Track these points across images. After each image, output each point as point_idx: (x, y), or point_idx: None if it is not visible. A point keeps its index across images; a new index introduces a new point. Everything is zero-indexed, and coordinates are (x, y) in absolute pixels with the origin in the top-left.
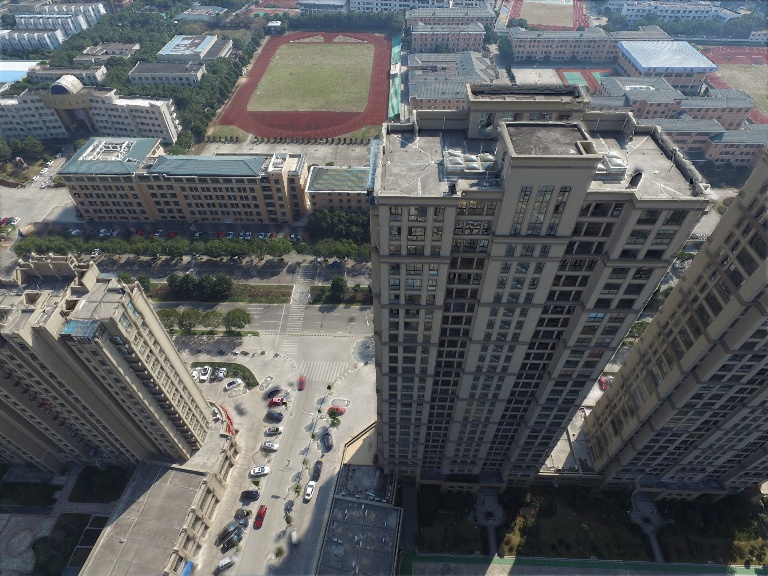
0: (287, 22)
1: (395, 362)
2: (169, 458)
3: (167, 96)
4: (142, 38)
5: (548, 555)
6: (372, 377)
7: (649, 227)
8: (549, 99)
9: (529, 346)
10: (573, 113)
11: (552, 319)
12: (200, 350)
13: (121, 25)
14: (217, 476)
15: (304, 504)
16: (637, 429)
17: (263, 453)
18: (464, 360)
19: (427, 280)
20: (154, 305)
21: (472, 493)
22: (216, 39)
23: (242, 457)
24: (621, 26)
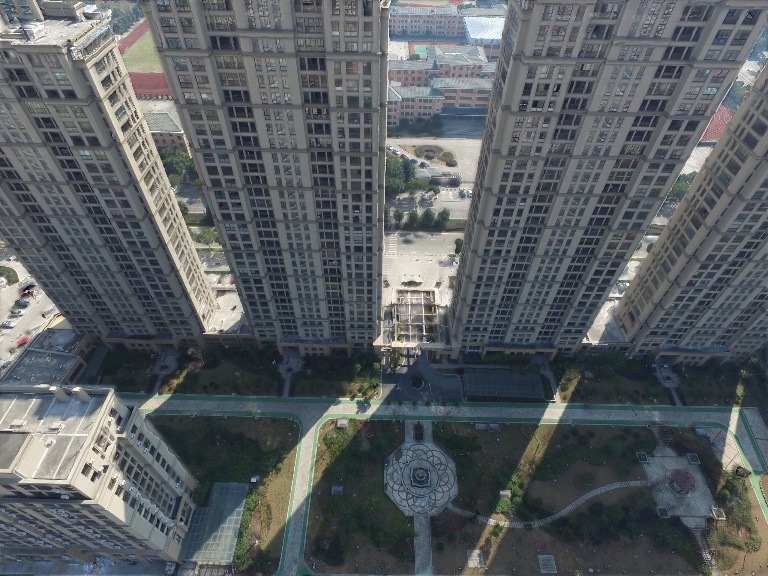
0: None
1: None
2: None
3: None
4: None
5: (198, 393)
6: None
7: (45, 70)
8: None
9: (76, 189)
10: None
11: (68, 161)
12: None
13: None
14: None
15: None
16: (236, 280)
17: None
18: (38, 203)
19: None
20: None
21: (154, 352)
22: (95, 8)
23: None
24: (485, 6)
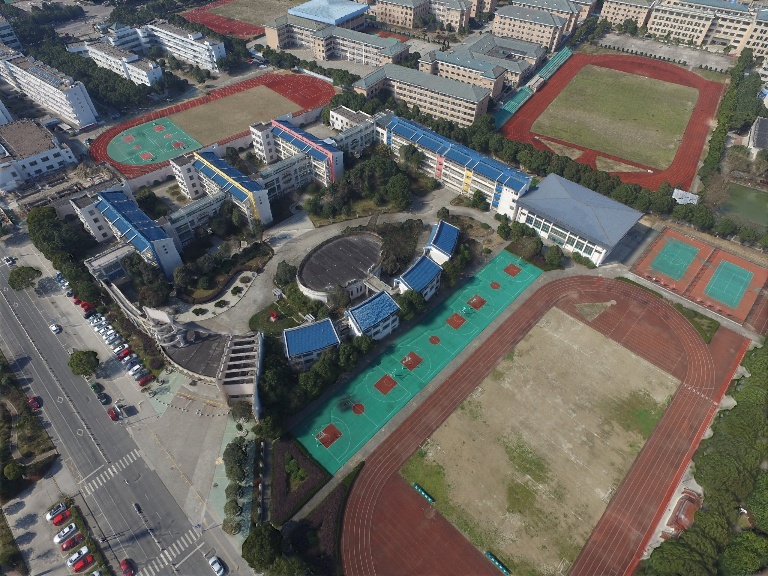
0: None
1: None
2: None
3: None
4: None
5: None
6: None
7: None
8: None
9: None
10: None
11: None
12: None
13: None
14: None
15: None
16: None
17: None
18: None
19: None
20: None
21: None
22: None
23: None
24: None
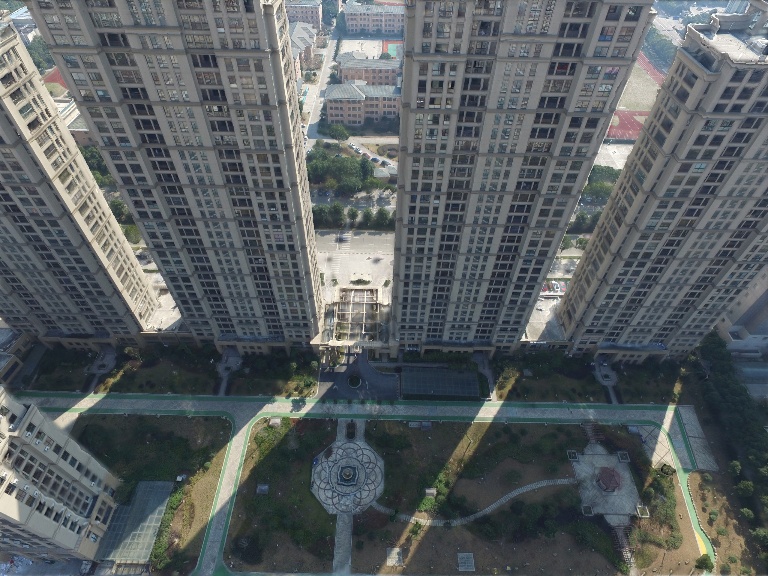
0: None
1: None
2: None
3: None
4: None
5: (133, 392)
6: None
7: None
8: None
9: None
10: None
11: None
12: None
13: None
14: None
15: None
16: None
17: None
18: None
19: None
20: None
21: (93, 350)
22: None
23: None
24: None
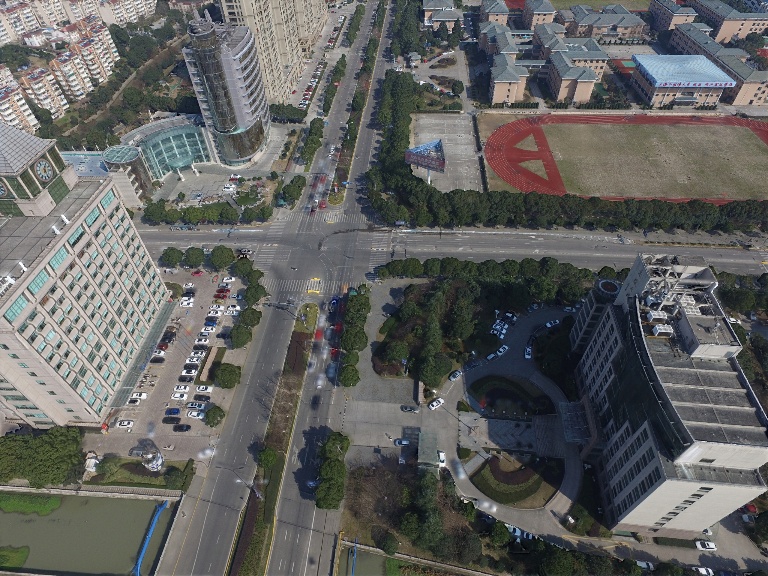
0: None
1: None
2: None
3: None
4: None
5: None
6: (344, 15)
7: None
8: None
9: None
10: None
11: None
12: None
13: None
14: None
15: None
16: None
17: None
18: None
19: None
20: None
21: None
22: None
23: None
24: None
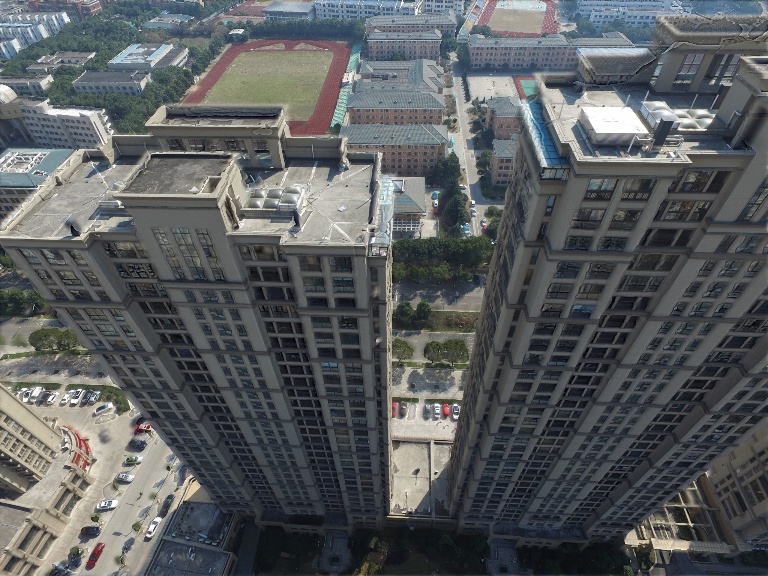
0: (249, 30)
1: (150, 407)
2: (1, 491)
3: (107, 105)
4: (99, 47)
5: None
6: None
7: (319, 274)
8: (247, 123)
9: (289, 393)
10: (267, 140)
11: (294, 366)
12: (80, 371)
13: (85, 34)
14: (51, 511)
15: (144, 543)
16: (465, 476)
17: (115, 485)
18: None
19: (118, 326)
20: (45, 322)
21: (319, 535)
22: (171, 47)
23: (93, 489)
24: (588, 32)
